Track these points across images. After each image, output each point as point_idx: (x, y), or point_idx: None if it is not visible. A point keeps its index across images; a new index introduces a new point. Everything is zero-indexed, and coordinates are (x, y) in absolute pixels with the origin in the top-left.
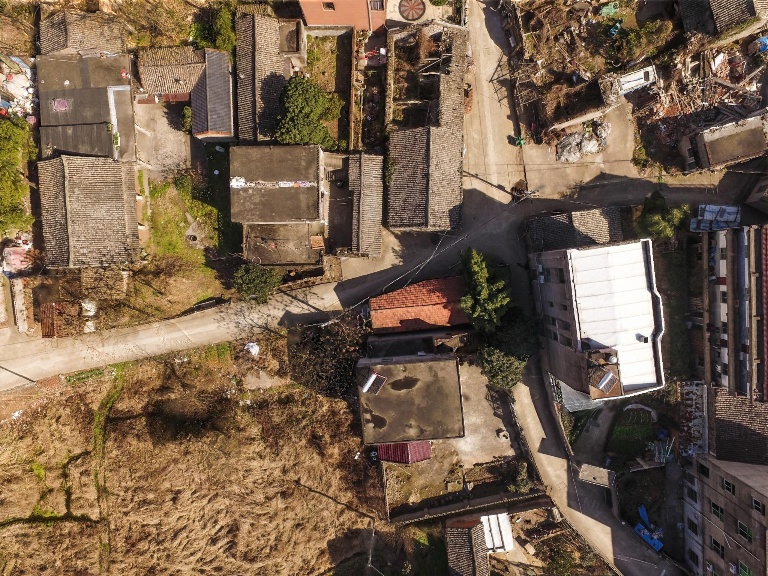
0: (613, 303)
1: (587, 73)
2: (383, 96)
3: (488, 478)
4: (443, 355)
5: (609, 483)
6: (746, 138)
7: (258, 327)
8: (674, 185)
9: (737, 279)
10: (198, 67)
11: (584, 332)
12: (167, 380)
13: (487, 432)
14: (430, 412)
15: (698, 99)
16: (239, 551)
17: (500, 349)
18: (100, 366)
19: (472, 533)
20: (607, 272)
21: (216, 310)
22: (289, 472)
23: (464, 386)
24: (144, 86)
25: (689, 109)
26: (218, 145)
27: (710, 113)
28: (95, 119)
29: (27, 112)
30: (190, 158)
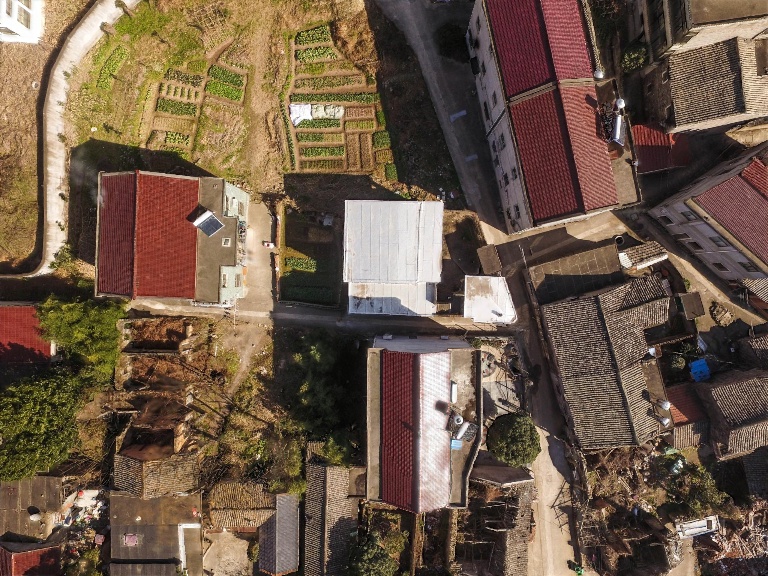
0: None
1: (649, 506)
2: (445, 515)
3: None
4: None
5: None
6: None
7: None
8: None
9: None
10: (268, 512)
11: None
12: None
13: None
14: None
15: (760, 547)
16: None
17: None
18: None
19: None
20: None
21: None
22: None
23: None
24: (214, 522)
25: (751, 554)
26: None
27: None
28: (164, 555)
29: (94, 518)
30: (252, 566)
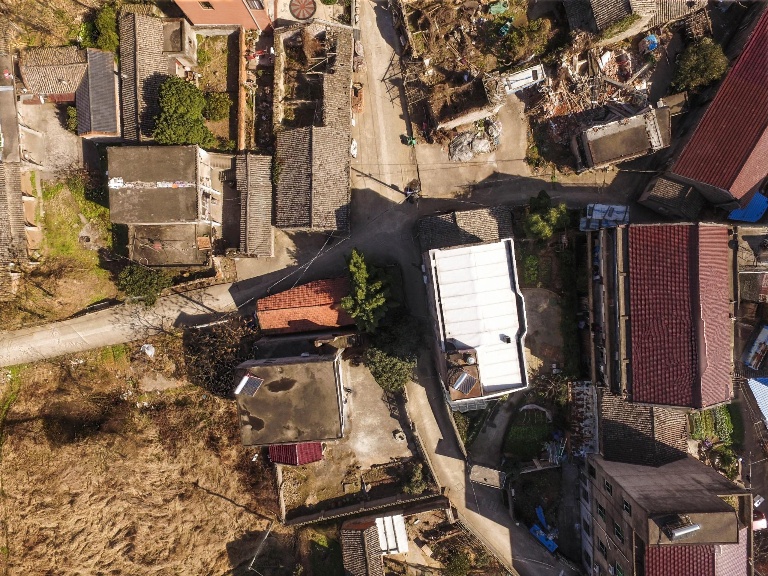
0: (476, 303)
1: None
2: None
3: (386, 479)
4: (325, 356)
5: (500, 484)
6: (629, 137)
7: (153, 328)
8: (567, 184)
9: (613, 278)
10: (80, 67)
11: (449, 332)
12: (63, 382)
13: (384, 433)
14: (307, 413)
15: (587, 98)
16: (137, 554)
17: (382, 350)
18: None
19: (365, 535)
20: (470, 272)
21: (111, 311)
22: (187, 474)
23: (360, 387)
24: (28, 86)
25: (579, 108)
26: (109, 145)
27: (600, 112)
28: None
29: None
30: (82, 159)
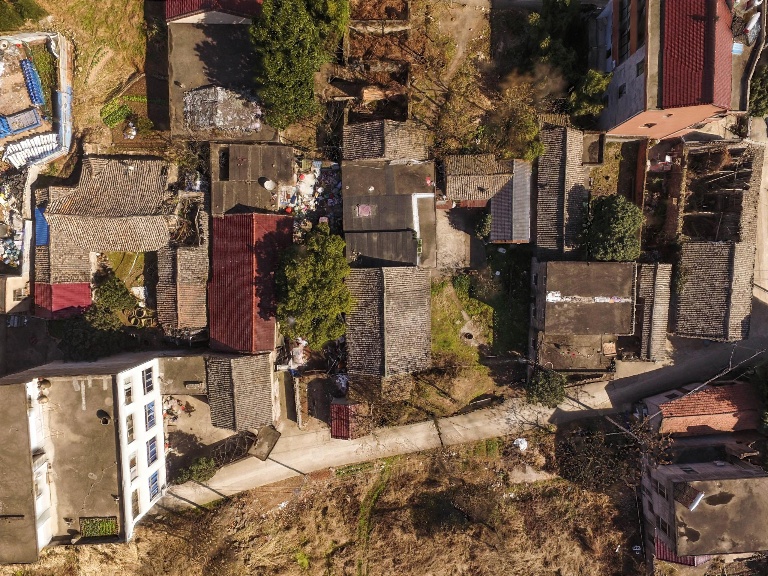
0: None
1: None
2: (662, 201)
3: (746, 572)
4: (744, 466)
5: None
6: None
7: (528, 423)
8: None
9: None
10: (505, 177)
11: None
12: (434, 473)
13: None
14: (743, 526)
15: None
16: None
17: None
18: (370, 460)
19: None
20: None
21: None
22: (551, 564)
23: None
24: (446, 193)
25: None
26: (501, 247)
27: None
28: (398, 225)
29: (311, 210)
30: (469, 257)
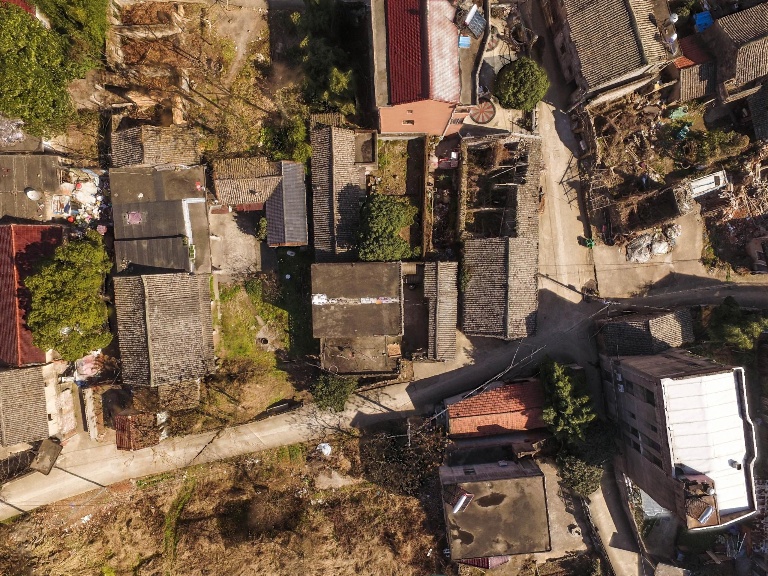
0: (706, 430)
1: (656, 175)
2: (453, 198)
3: (560, 572)
4: (525, 466)
5: None
6: None
7: (330, 428)
8: (742, 284)
9: None
10: (274, 180)
11: (677, 458)
12: (238, 482)
13: (559, 527)
14: (517, 527)
15: (767, 202)
16: None
17: (581, 459)
18: (171, 470)
19: None
20: (700, 400)
21: (288, 412)
22: (362, 570)
23: None
24: (219, 198)
25: (758, 211)
26: (289, 250)
27: None
28: (170, 232)
29: (95, 218)
30: (260, 262)
